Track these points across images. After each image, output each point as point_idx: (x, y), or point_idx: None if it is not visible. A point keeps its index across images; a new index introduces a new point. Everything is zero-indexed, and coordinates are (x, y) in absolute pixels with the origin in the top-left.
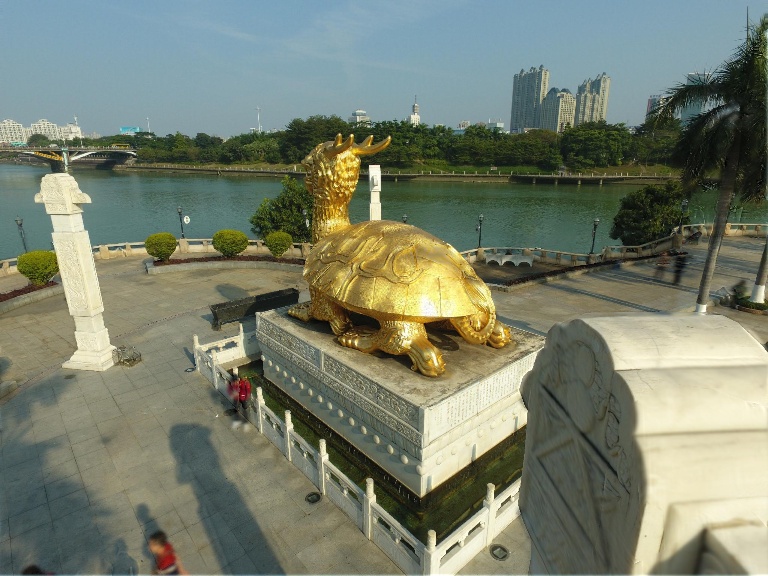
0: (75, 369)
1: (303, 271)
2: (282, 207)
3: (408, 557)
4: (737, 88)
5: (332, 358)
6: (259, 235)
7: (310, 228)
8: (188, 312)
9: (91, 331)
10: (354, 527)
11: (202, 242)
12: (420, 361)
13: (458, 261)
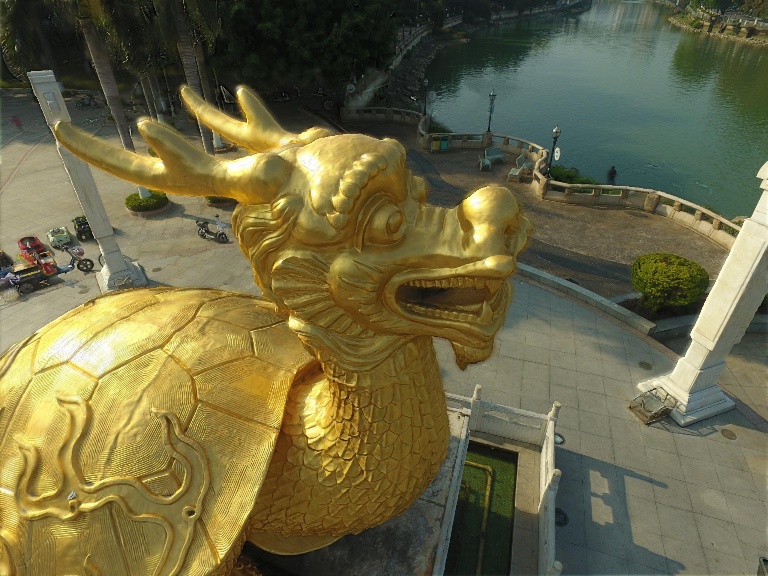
0: None
1: None
2: None
3: None
4: None
5: None
6: None
7: None
8: None
9: None
10: None
11: None
12: None
13: None
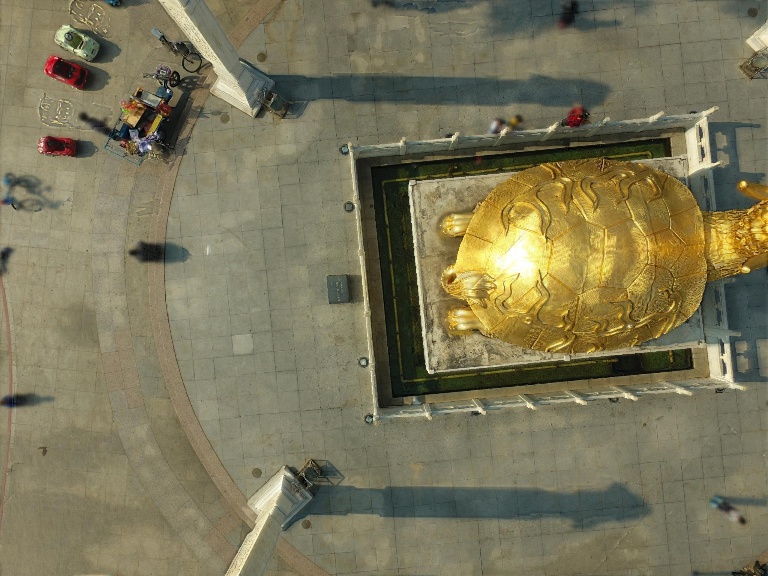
0: None
1: None
2: None
3: None
4: None
5: None
6: None
7: None
8: None
9: None
10: None
11: None
12: None
13: (509, 285)
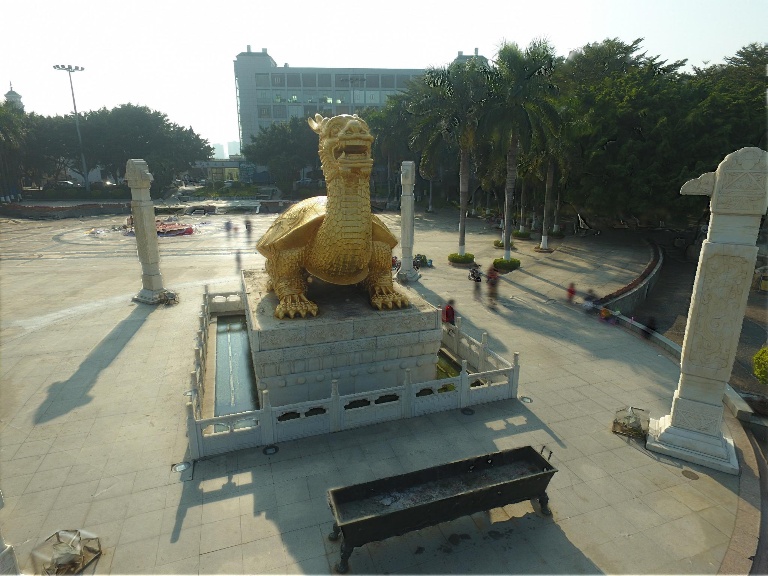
0: None
1: None
2: None
3: None
4: None
5: None
6: None
7: None
8: None
9: None
10: None
11: None
12: None
13: None
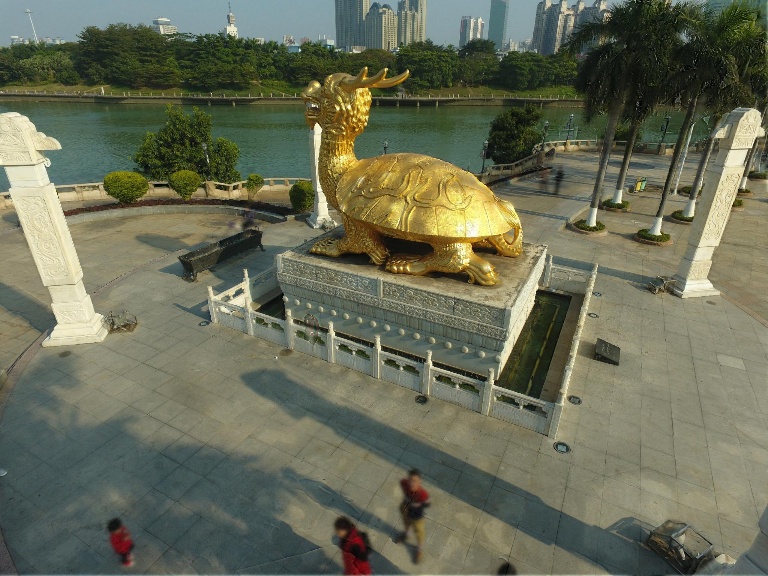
0: (63, 345)
1: (340, 208)
2: (171, 141)
3: (534, 416)
4: (627, 29)
5: (395, 284)
6: (146, 175)
7: (211, 164)
8: (138, 268)
9: (74, 300)
10: (469, 411)
11: (74, 188)
12: (480, 274)
13: None
